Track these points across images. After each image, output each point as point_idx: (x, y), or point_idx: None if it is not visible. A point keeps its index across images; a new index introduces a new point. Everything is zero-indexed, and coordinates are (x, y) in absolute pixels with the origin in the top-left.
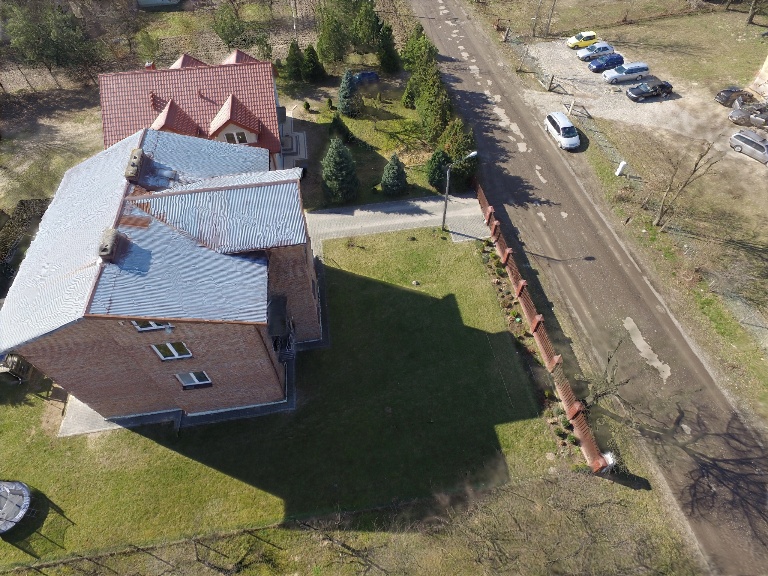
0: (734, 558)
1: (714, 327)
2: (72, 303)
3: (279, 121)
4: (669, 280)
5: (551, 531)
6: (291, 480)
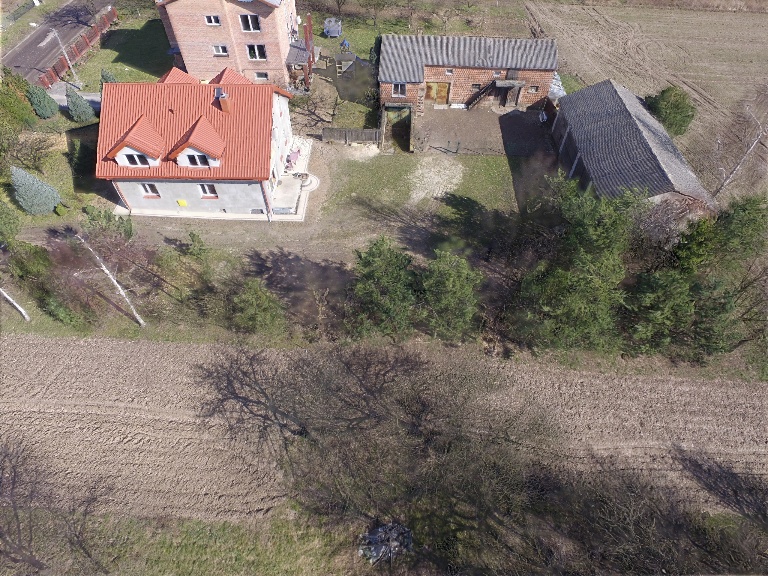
0: (97, 5)
1: (5, 41)
2: None
3: None
4: None
5: (146, 13)
6: None
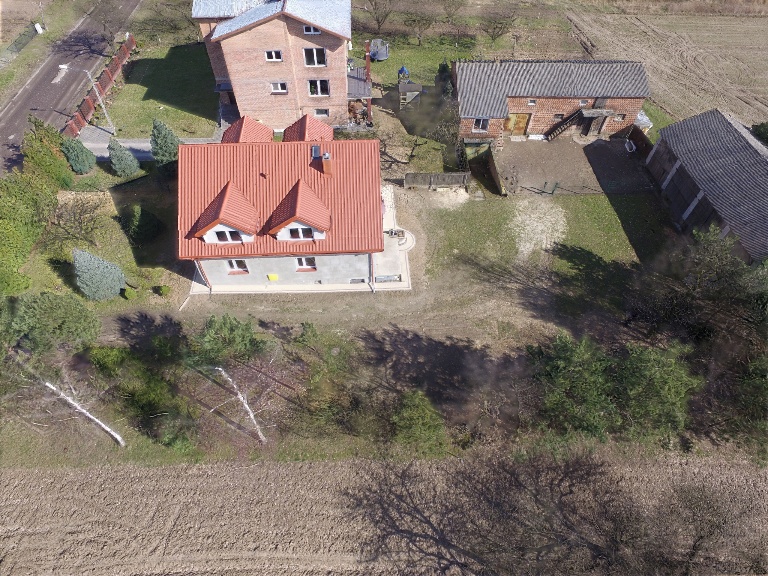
0: None
1: None
2: None
3: None
4: (1, 96)
5: None
6: None
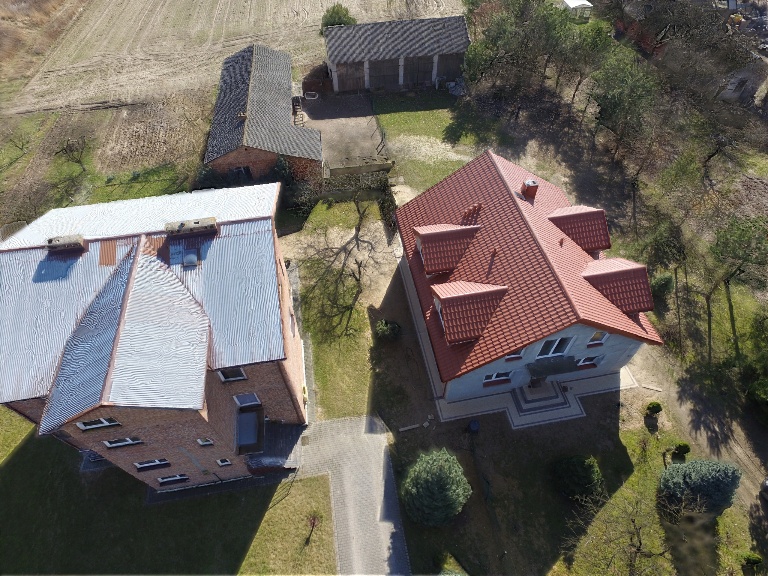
0: None
1: None
2: (6, 240)
3: (534, 367)
4: None
5: None
6: (6, 479)
